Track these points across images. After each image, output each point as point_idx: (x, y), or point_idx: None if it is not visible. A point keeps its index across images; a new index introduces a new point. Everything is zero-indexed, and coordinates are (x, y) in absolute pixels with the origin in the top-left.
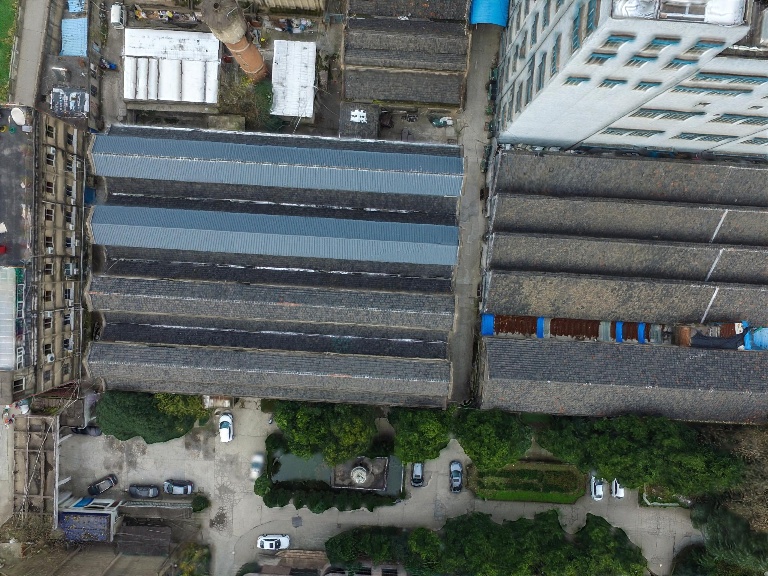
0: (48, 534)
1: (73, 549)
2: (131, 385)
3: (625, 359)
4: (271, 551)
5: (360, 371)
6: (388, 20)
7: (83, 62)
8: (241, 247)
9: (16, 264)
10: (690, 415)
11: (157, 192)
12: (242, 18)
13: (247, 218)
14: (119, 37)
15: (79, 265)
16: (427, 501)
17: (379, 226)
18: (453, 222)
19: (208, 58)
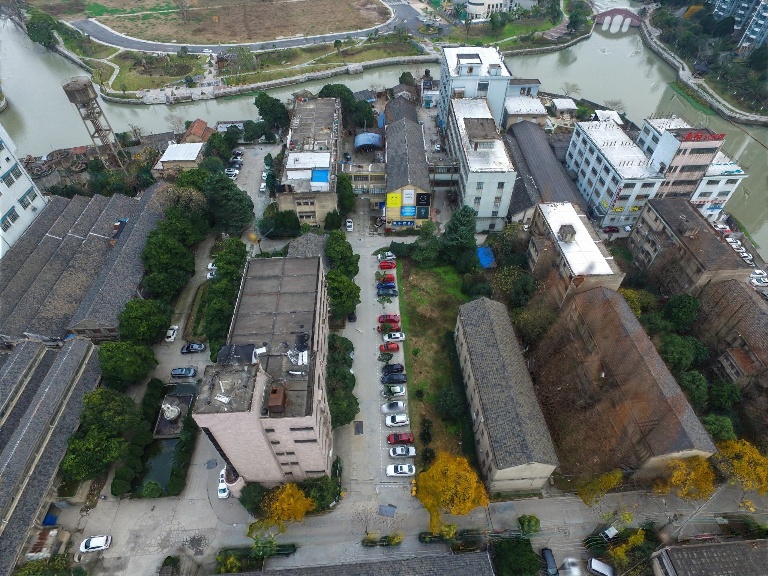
0: None
1: None
2: None
3: None
4: None
5: None
6: None
7: None
8: None
9: None
10: None
11: None
12: None
13: None
14: None
15: None
16: None
17: None
18: None
19: None
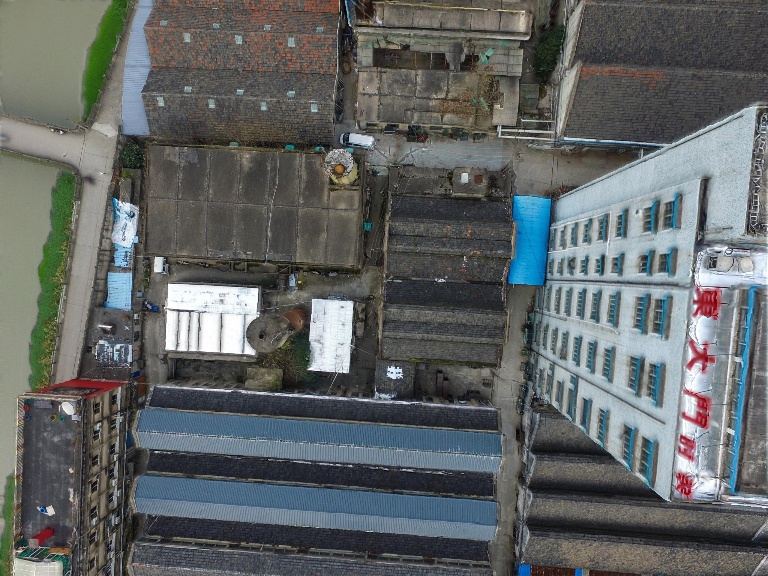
0: None
1: None
2: None
3: None
4: None
5: None
6: (425, 282)
7: (127, 316)
8: (279, 520)
9: (63, 545)
10: None
11: (197, 452)
12: (285, 334)
13: (285, 492)
14: (161, 280)
15: (120, 511)
16: None
17: (416, 502)
18: (490, 487)
19: (247, 311)
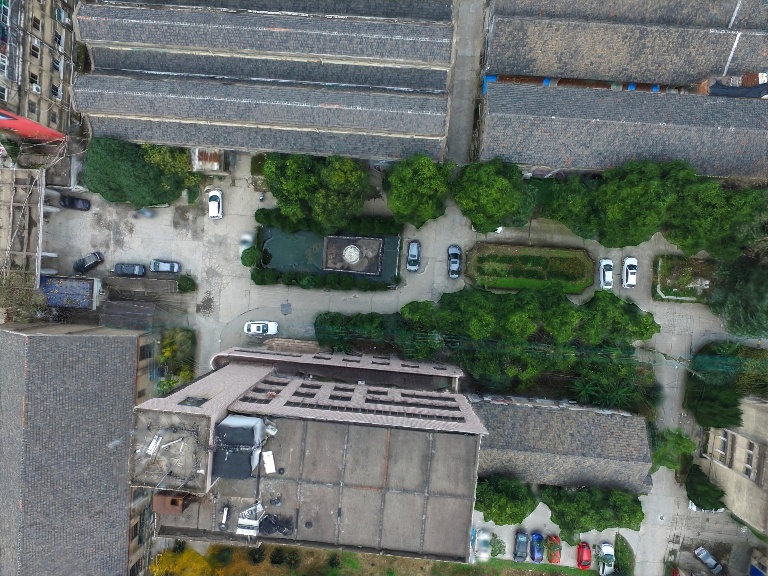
0: (30, 299)
1: (55, 322)
2: (118, 133)
3: (637, 102)
4: (258, 339)
5: (352, 103)
6: None
7: None
8: None
9: None
10: (708, 168)
11: None
12: None
13: None
14: None
15: None
16: (423, 289)
17: None
18: None
19: None
